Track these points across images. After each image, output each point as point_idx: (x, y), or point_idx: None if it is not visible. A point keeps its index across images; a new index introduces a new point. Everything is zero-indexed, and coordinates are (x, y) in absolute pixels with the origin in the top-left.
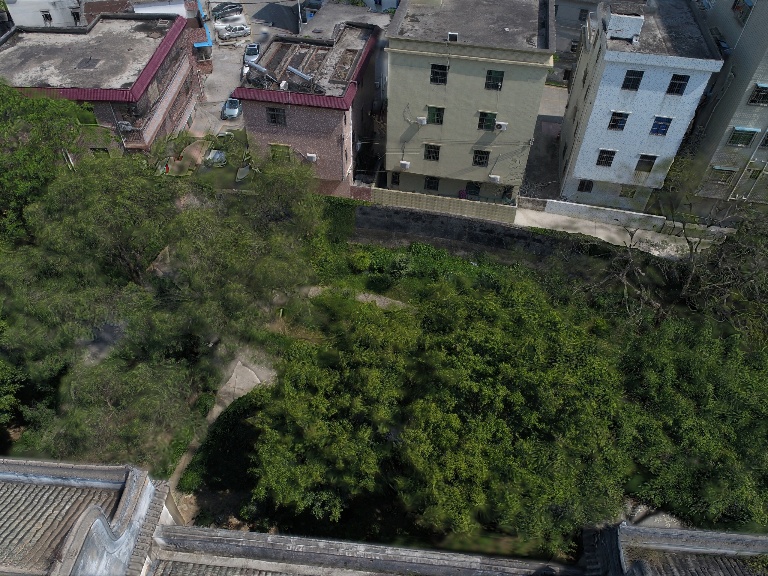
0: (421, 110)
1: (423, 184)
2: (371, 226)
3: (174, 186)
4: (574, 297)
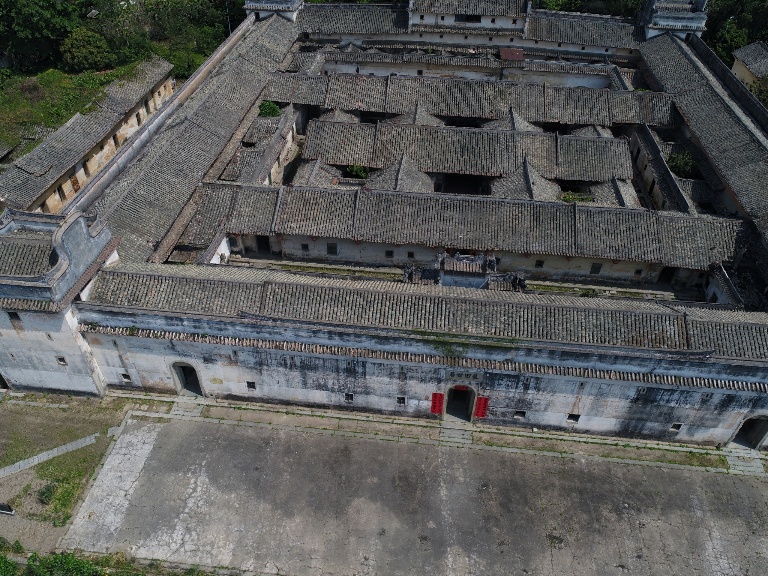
0: None
1: None
2: None
3: None
4: None
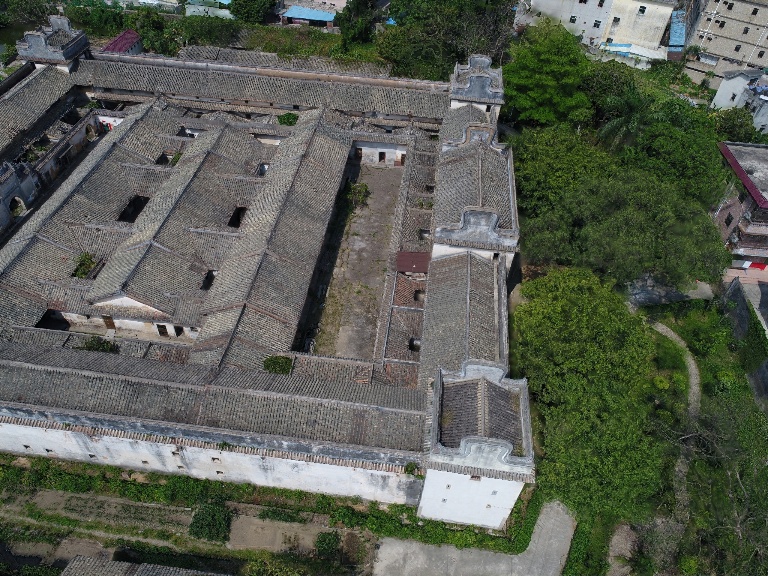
0: None
1: None
2: (762, 378)
3: (663, 212)
4: (764, 538)
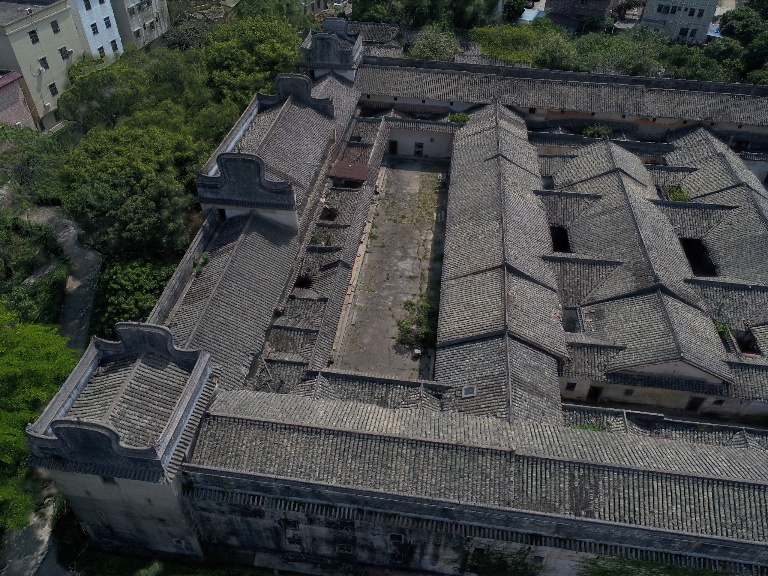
0: (37, 65)
1: (54, 119)
2: None
3: None
4: None
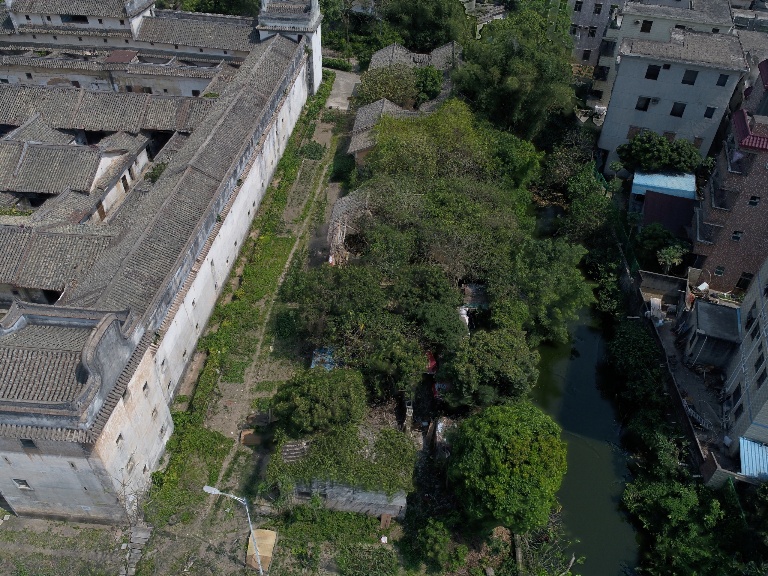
0: None
1: None
2: None
3: None
4: None
